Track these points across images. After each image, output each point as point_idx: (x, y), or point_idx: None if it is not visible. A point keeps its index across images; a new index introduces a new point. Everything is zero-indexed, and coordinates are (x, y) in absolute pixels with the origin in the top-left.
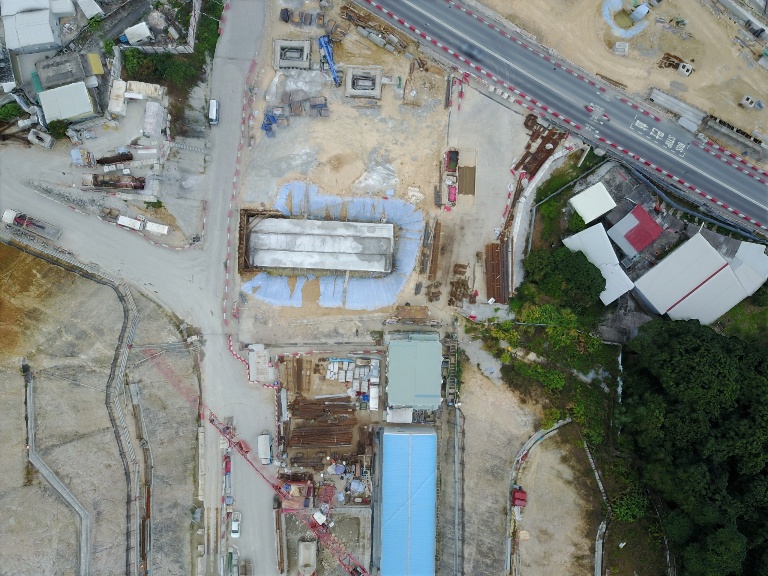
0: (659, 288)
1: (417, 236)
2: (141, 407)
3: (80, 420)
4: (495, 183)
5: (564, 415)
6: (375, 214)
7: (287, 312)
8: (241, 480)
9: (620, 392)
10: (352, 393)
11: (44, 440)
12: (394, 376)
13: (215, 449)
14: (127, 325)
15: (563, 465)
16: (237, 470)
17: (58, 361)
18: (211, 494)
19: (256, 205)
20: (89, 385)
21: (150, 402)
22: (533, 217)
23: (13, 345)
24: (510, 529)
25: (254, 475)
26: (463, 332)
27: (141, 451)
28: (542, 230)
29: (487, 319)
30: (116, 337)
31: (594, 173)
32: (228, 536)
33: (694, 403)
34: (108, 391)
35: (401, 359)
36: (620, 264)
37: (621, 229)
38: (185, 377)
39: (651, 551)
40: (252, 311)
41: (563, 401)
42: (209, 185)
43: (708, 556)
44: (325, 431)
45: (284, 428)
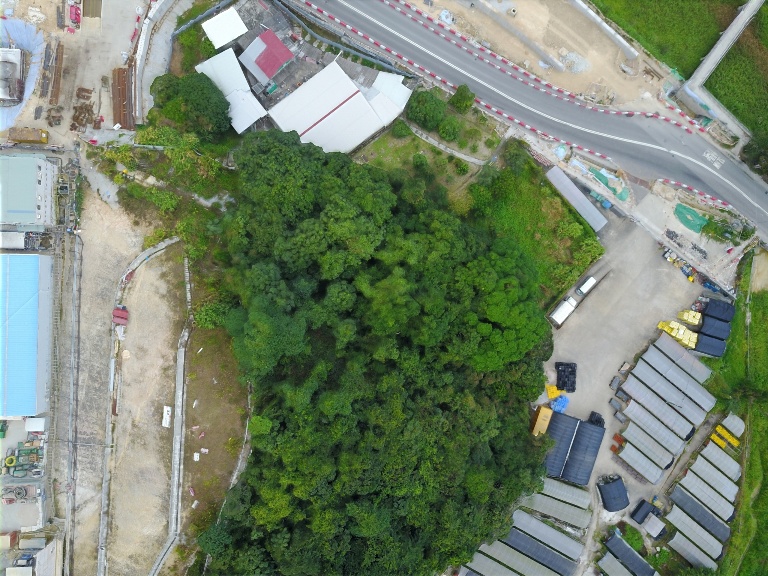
0: (291, 116)
1: (39, 59)
2: None
3: None
4: (123, 6)
5: (170, 233)
6: (2, 39)
7: None
8: None
9: None
10: None
11: None
12: None
13: None
14: None
15: (160, 280)
16: None
17: None
18: None
19: None
20: None
21: None
22: (170, 45)
23: None
24: (114, 350)
25: None
26: (85, 157)
27: None
28: (182, 60)
29: (106, 142)
30: None
31: (237, 2)
32: None
33: (263, 202)
34: None
35: None
36: (252, 91)
37: (251, 54)
38: None
39: (233, 358)
40: None
41: (175, 222)
42: None
43: (244, 341)
44: None
45: None
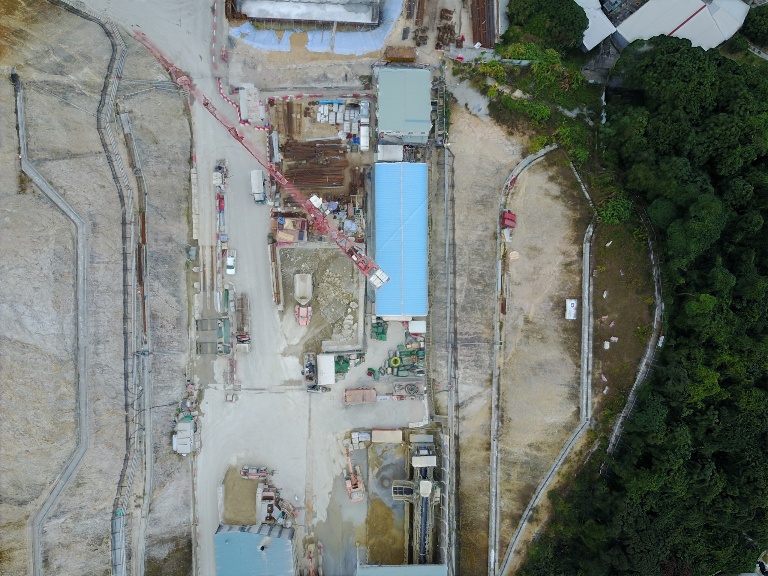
0: (640, 31)
1: None
2: (133, 136)
3: (72, 140)
4: None
5: (551, 140)
6: None
7: (276, 56)
8: (235, 220)
9: (604, 122)
10: (343, 135)
11: (36, 152)
12: (384, 101)
13: (208, 191)
14: (116, 57)
15: (550, 183)
16: (231, 211)
17: (47, 77)
18: (205, 233)
19: None
20: (80, 107)
21: (142, 134)
22: None
23: (1, 56)
24: (500, 252)
25: (248, 215)
26: (451, 75)
27: (134, 179)
28: None
29: (474, 59)
30: (105, 66)
31: None
32: (224, 274)
33: (675, 99)
34: (99, 116)
35: (391, 85)
36: (602, 8)
37: None
38: (176, 117)
39: (636, 252)
40: (241, 55)
41: (549, 131)
42: None
43: (690, 223)
44: (317, 171)
45: (276, 169)
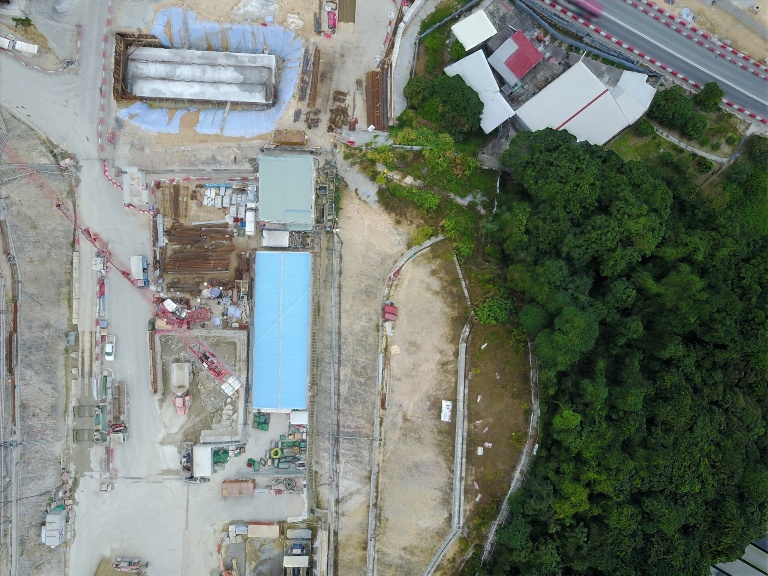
0: (539, 115)
1: (296, 63)
2: (8, 222)
3: None
4: (376, 11)
5: (436, 231)
6: (257, 45)
7: (164, 138)
8: (116, 305)
9: (494, 211)
10: (229, 219)
11: None
12: (264, 190)
13: (90, 274)
14: None
15: (432, 277)
16: (112, 295)
17: None
18: (85, 318)
19: (132, 31)
20: None
21: (18, 219)
22: (416, 48)
23: None
24: (382, 345)
25: (130, 300)
26: (342, 158)
27: (8, 266)
28: (426, 62)
29: (365, 143)
30: None
31: (479, 5)
32: (103, 360)
33: (552, 199)
34: None
35: (271, 174)
36: (500, 91)
37: (501, 55)
38: None
39: (514, 354)
40: (128, 137)
41: (437, 220)
42: (84, 10)
43: (555, 336)
44: (201, 256)
45: (160, 253)
